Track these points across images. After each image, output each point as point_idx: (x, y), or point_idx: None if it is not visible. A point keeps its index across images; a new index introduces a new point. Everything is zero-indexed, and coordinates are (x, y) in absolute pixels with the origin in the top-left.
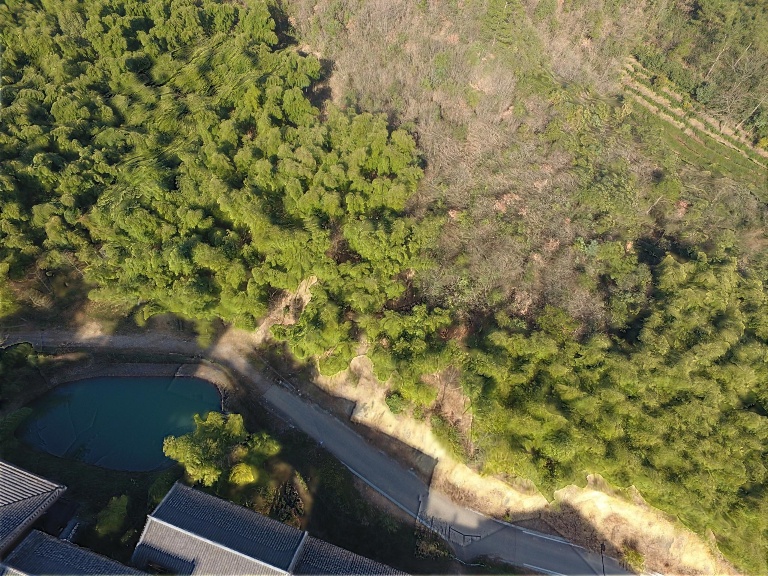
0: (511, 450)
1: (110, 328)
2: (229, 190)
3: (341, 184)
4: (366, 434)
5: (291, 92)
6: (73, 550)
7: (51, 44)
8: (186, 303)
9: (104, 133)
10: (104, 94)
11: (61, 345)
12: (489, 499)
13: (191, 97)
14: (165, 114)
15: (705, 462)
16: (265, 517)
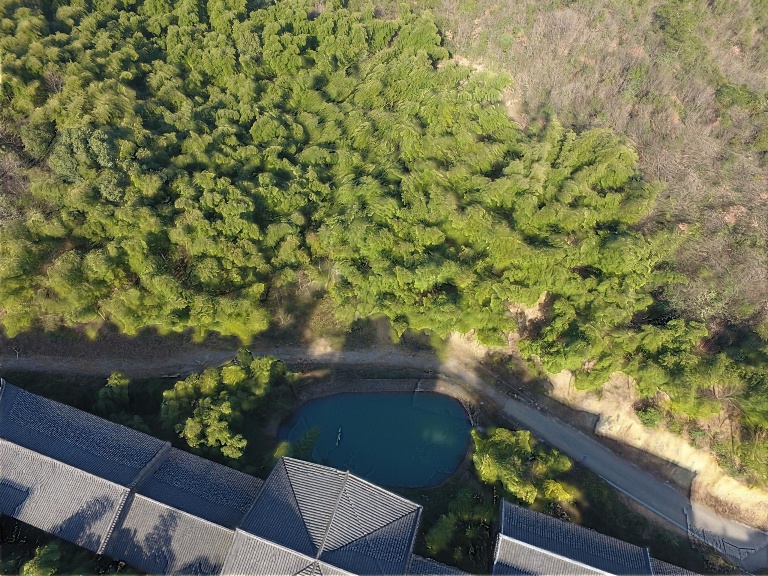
0: None
1: (339, 344)
2: (461, 207)
3: (573, 199)
4: (614, 447)
5: (479, 107)
6: (443, 569)
7: (234, 64)
8: (439, 320)
9: (310, 151)
10: (289, 112)
11: (298, 362)
12: (755, 512)
13: (377, 113)
14: (357, 131)
15: None
16: (600, 534)
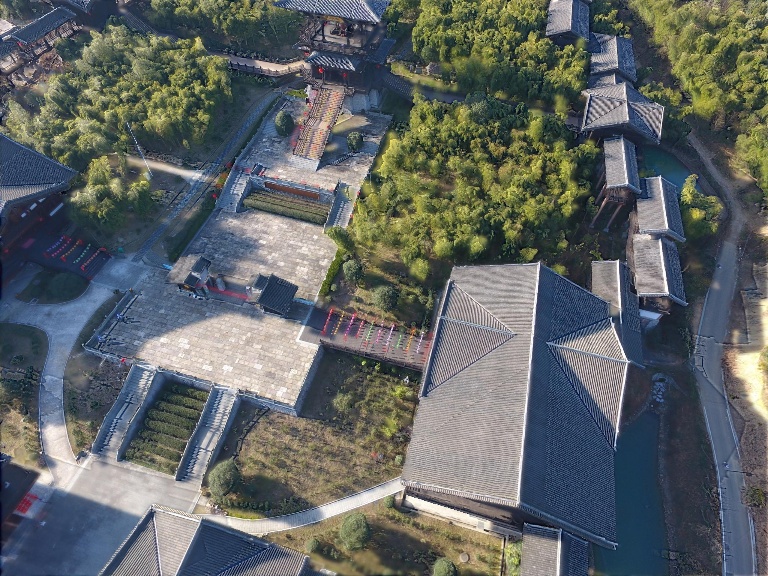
0: None
1: (717, 161)
2: None
3: None
4: (737, 301)
5: None
6: (634, 157)
7: None
8: None
9: None
10: None
11: (693, 147)
12: (739, 382)
13: None
14: None
15: None
16: None
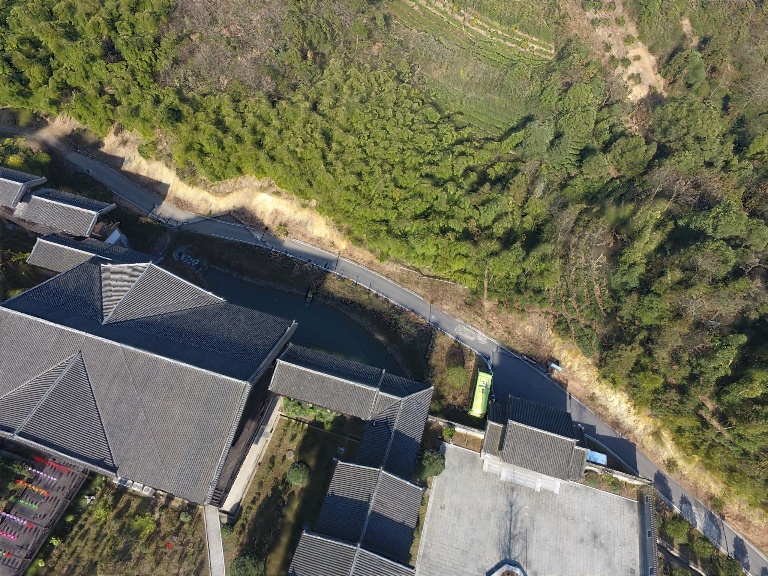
0: (185, 149)
1: None
2: (40, 22)
3: (115, 16)
4: (129, 176)
5: None
6: None
7: None
8: (4, 88)
9: None
10: None
11: None
12: (199, 205)
13: None
14: None
15: (296, 149)
16: (22, 172)
